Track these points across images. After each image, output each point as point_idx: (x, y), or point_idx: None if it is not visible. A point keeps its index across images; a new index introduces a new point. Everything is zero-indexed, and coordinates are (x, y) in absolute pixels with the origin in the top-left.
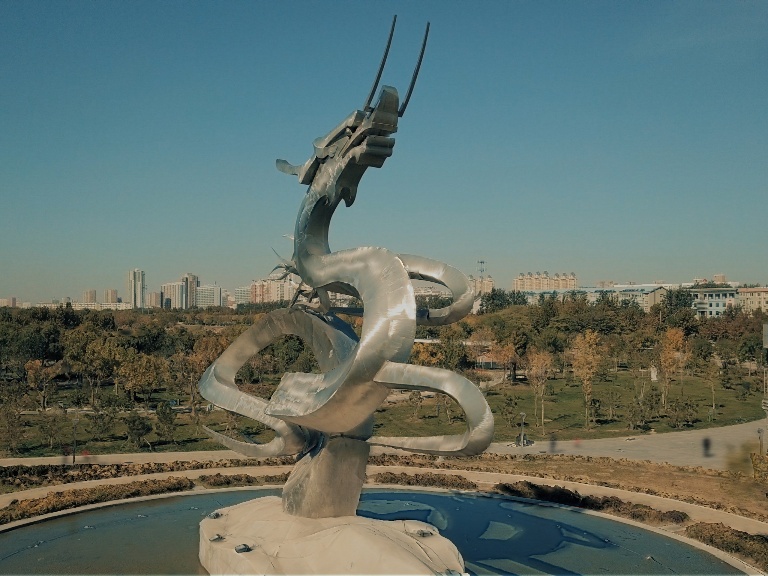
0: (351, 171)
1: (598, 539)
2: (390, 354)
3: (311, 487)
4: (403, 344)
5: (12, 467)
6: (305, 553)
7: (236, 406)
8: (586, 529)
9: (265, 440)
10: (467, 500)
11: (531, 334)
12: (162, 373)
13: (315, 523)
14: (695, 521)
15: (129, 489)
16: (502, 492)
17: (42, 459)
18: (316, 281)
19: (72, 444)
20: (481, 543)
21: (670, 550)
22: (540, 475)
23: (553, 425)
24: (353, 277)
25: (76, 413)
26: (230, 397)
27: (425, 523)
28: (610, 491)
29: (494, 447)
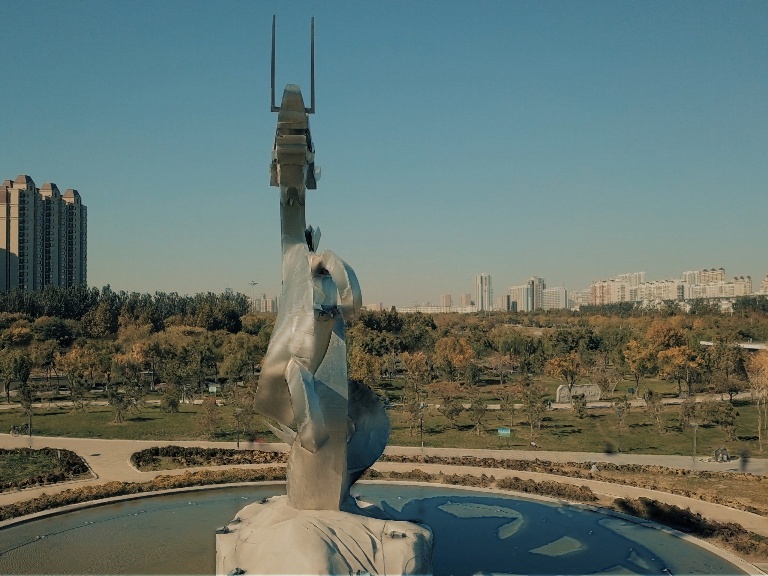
0: (290, 171)
1: (659, 568)
2: (294, 349)
3: (291, 478)
4: (304, 339)
5: (190, 448)
6: (263, 540)
7: None
8: (661, 556)
9: (439, 439)
10: (568, 513)
11: None
12: (374, 371)
13: (293, 514)
14: None
15: (254, 474)
16: (618, 508)
17: (229, 444)
18: None
19: (266, 432)
20: (526, 557)
21: None
22: (686, 494)
23: None
24: None
25: None
26: None
27: (416, 526)
28: (751, 518)
29: (681, 461)
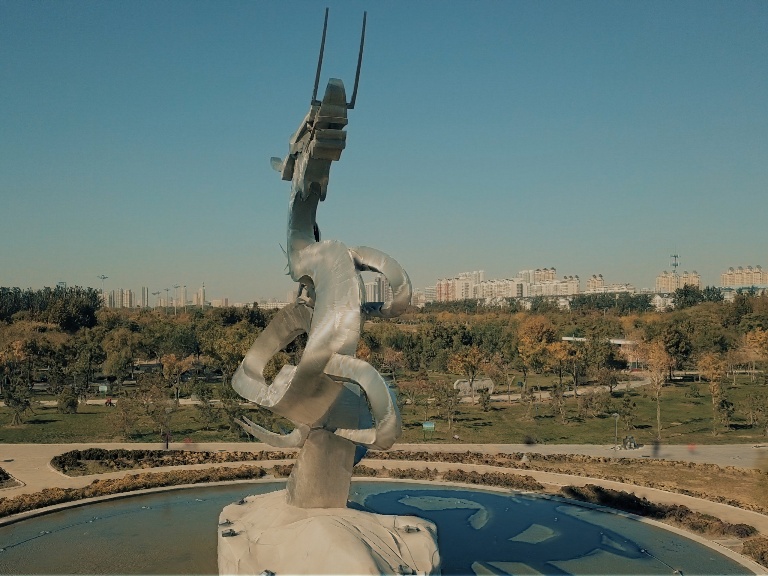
0: (316, 165)
1: (635, 549)
2: (336, 346)
3: (299, 477)
4: (348, 336)
5: (114, 451)
6: (280, 541)
7: (257, 397)
8: (631, 538)
9: None
10: (524, 501)
11: (686, 332)
12: None
13: (302, 513)
14: (763, 536)
15: (199, 475)
16: (567, 495)
17: (149, 445)
18: (295, 275)
19: (183, 432)
20: (509, 545)
21: (711, 565)
22: (620, 480)
23: (679, 429)
24: (314, 270)
25: (201, 404)
26: (252, 389)
27: (422, 519)
28: (688, 500)
29: (595, 449)
